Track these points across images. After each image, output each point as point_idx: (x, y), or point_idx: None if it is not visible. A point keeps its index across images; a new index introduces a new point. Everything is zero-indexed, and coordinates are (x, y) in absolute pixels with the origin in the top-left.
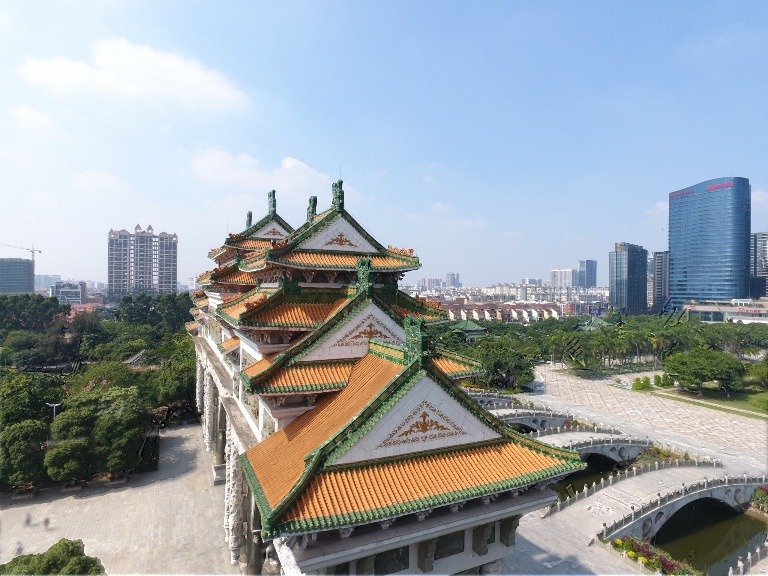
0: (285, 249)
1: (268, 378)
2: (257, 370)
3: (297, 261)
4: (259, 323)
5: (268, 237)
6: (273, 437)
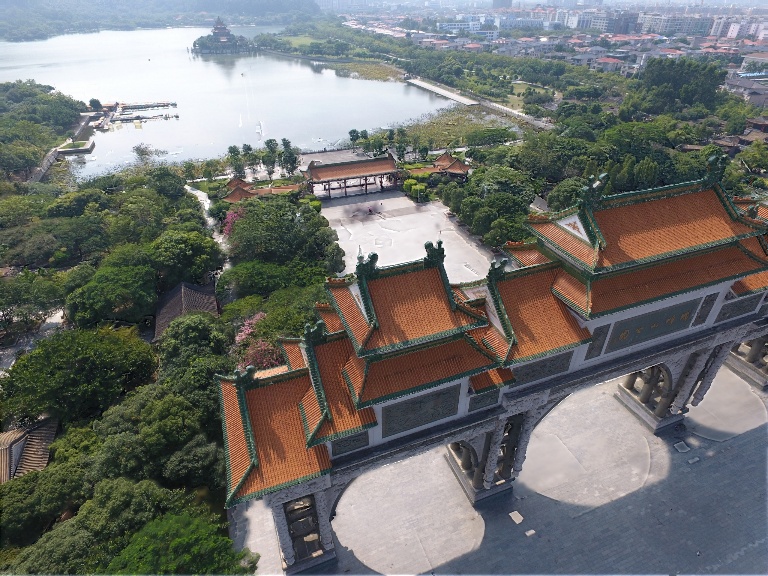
0: (341, 284)
1: (288, 342)
2: None
3: (335, 296)
4: (319, 316)
5: (569, 229)
6: None
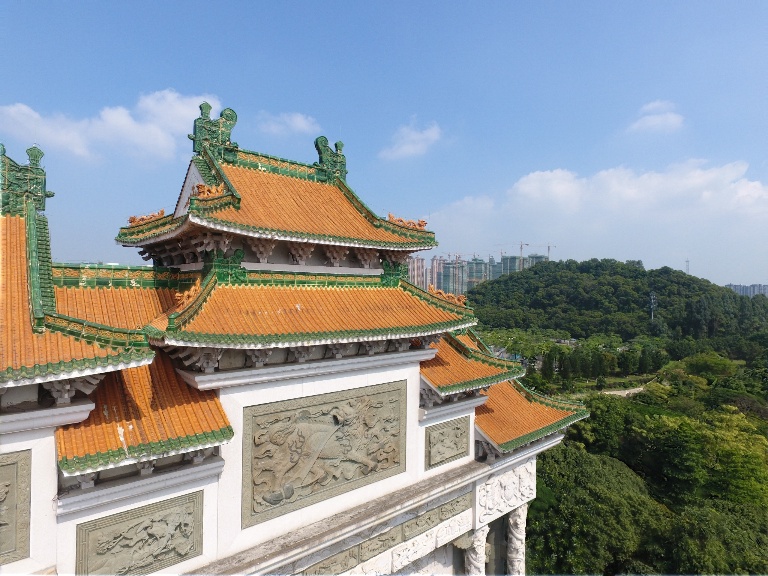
0: (396, 227)
1: None
2: (455, 374)
3: None
4: None
5: None
6: (482, 423)
